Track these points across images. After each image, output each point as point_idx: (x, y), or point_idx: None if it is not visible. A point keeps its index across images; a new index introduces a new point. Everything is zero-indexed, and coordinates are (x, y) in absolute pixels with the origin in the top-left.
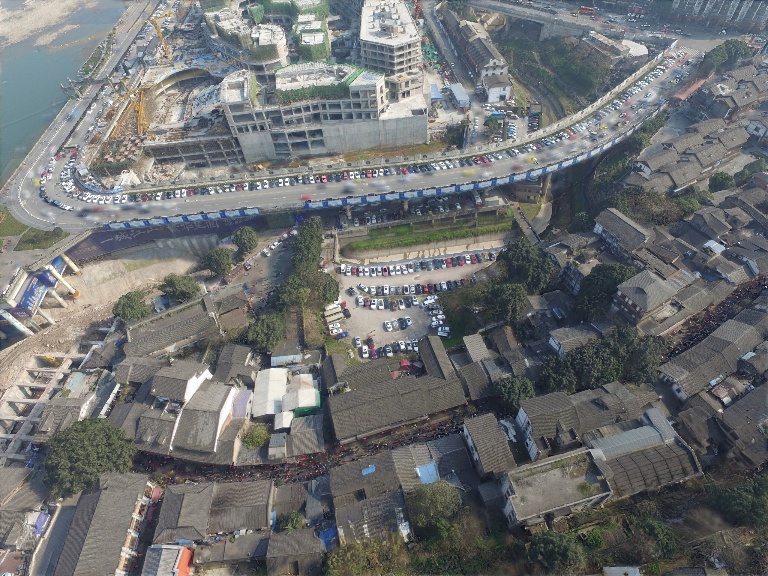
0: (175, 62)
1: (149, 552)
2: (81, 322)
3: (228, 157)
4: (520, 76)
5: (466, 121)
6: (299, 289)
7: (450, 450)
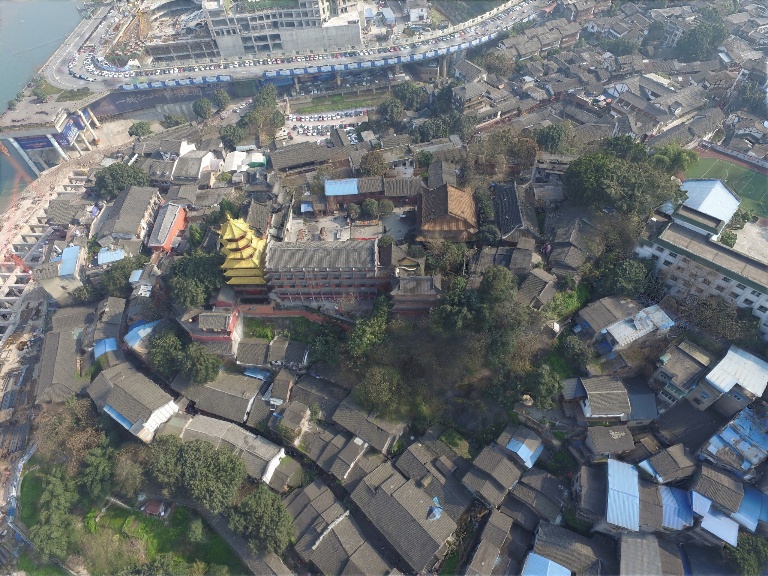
0: None
1: (161, 210)
2: (104, 152)
3: (209, 57)
4: (443, 10)
5: (390, 31)
6: (256, 113)
7: (340, 170)
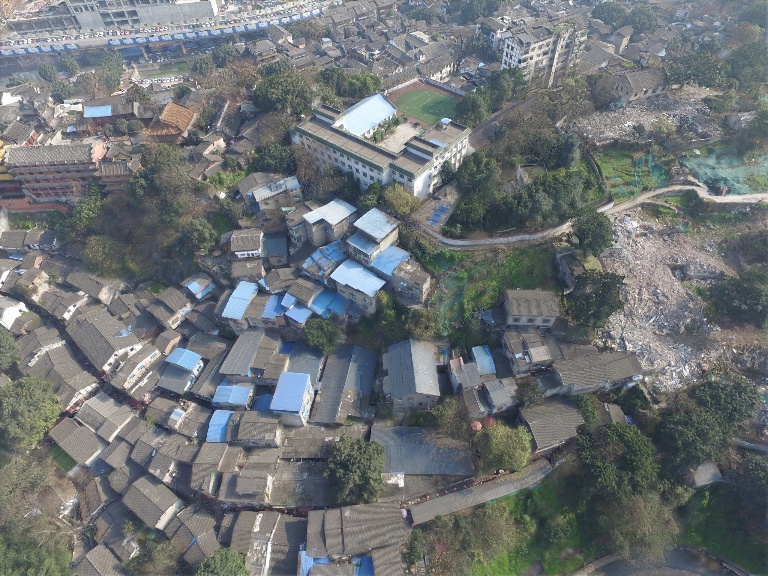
0: None
1: None
2: None
3: None
4: None
5: None
6: None
7: None
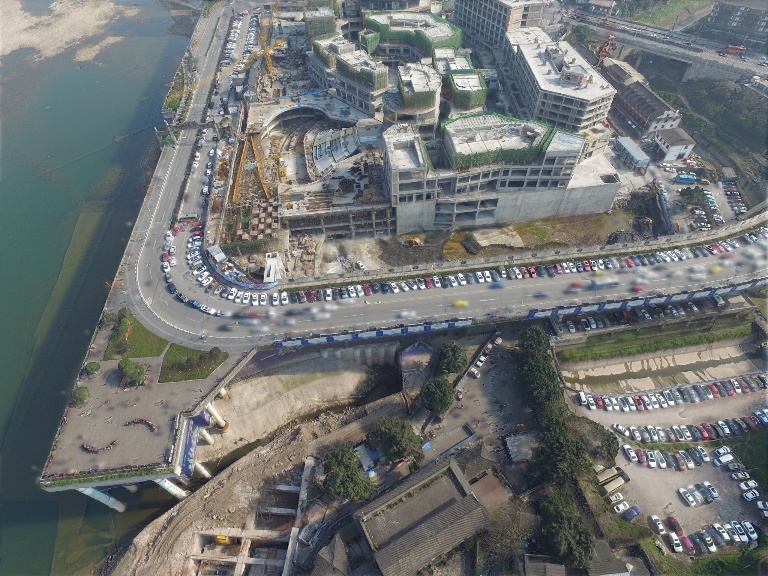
0: (279, 98)
1: None
2: (251, 477)
3: (377, 228)
4: None
5: None
6: (586, 457)
7: None
